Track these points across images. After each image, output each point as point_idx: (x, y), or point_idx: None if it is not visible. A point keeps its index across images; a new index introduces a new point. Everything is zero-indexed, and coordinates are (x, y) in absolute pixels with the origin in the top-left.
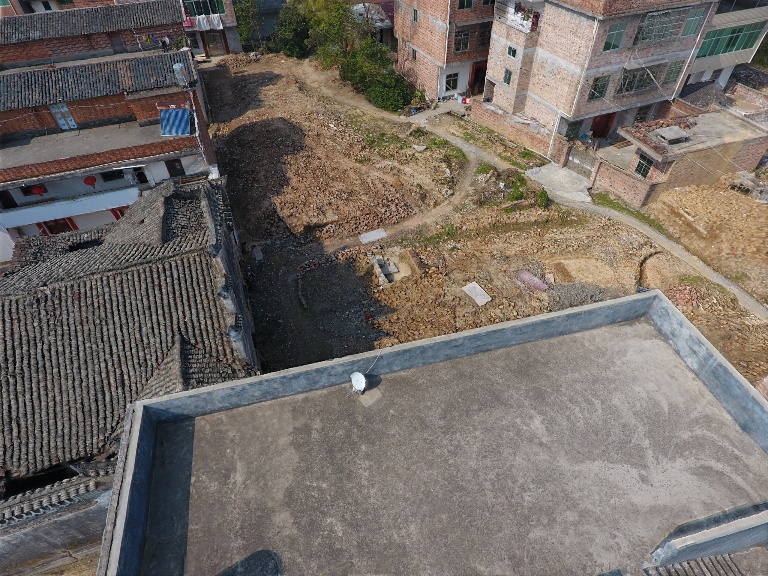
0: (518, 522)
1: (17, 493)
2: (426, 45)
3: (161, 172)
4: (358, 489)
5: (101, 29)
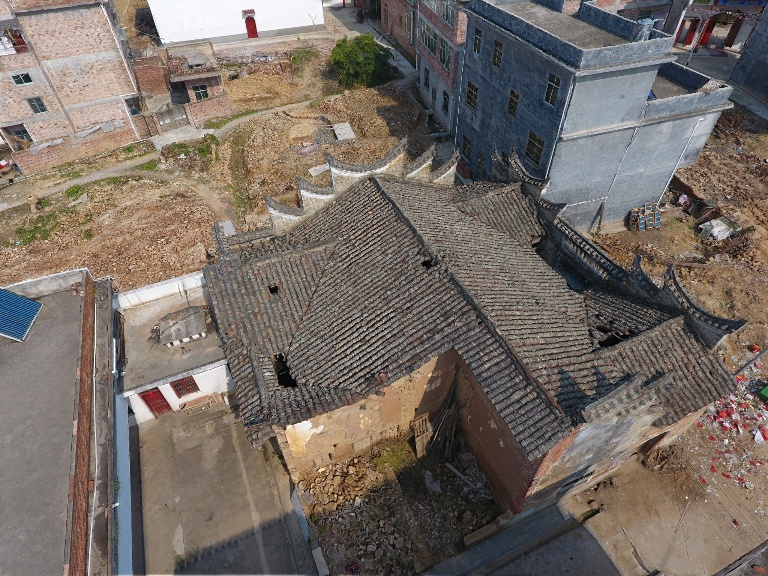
0: (566, 22)
1: None
2: None
3: None
4: (574, 38)
5: None
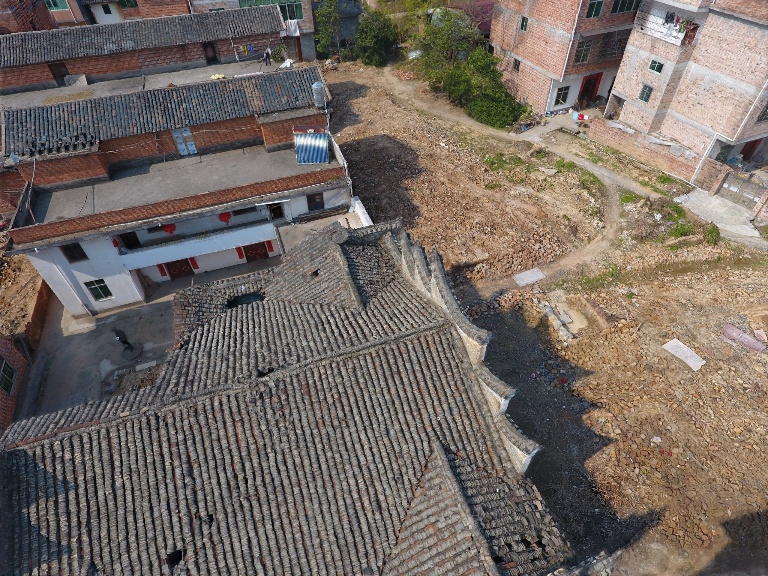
0: None
1: None
2: (536, 56)
3: (300, 206)
4: None
5: (197, 39)
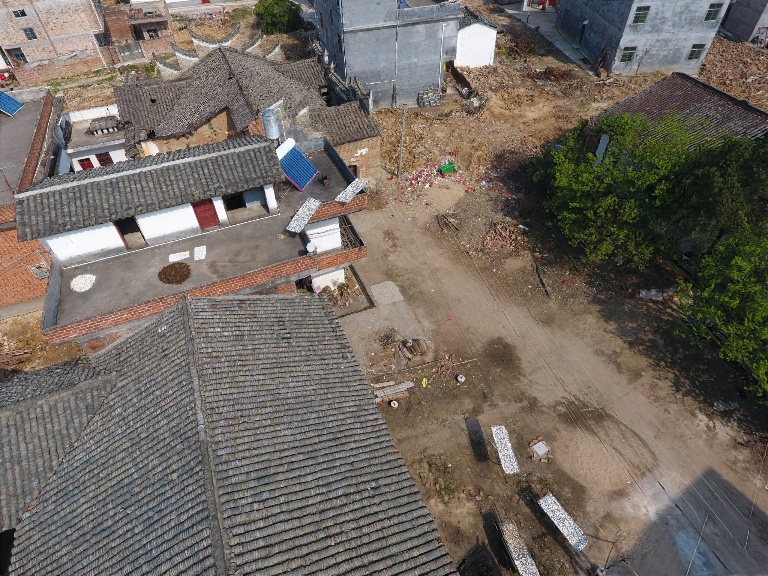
0: None
1: None
2: None
3: (59, 129)
4: None
5: None
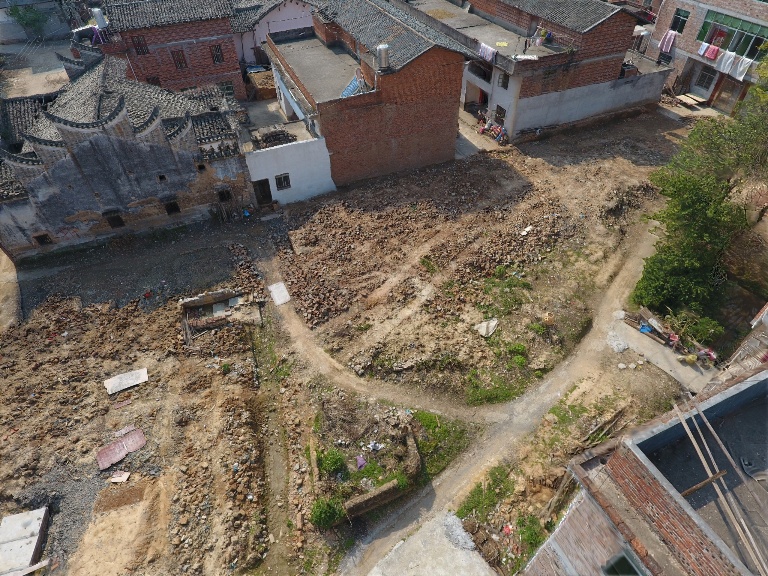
0: None
1: None
2: None
3: None
4: None
5: (528, 8)
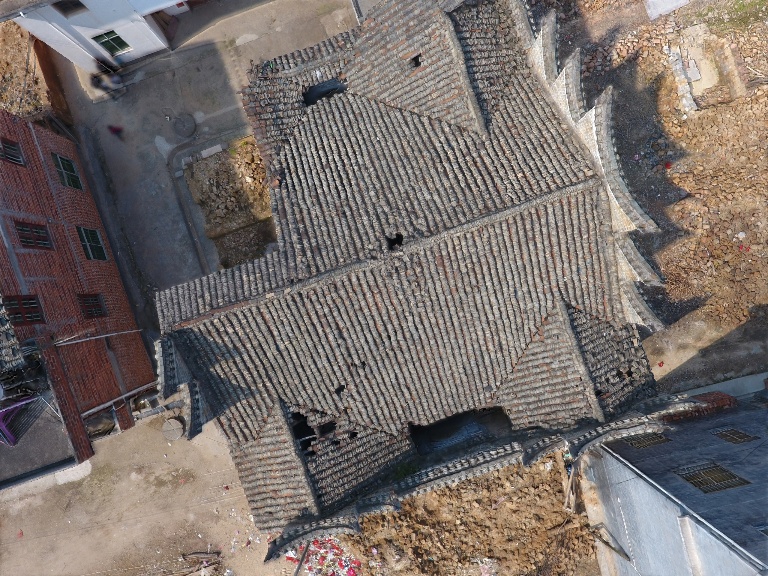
0: None
1: (419, 434)
2: None
3: None
4: None
5: None
